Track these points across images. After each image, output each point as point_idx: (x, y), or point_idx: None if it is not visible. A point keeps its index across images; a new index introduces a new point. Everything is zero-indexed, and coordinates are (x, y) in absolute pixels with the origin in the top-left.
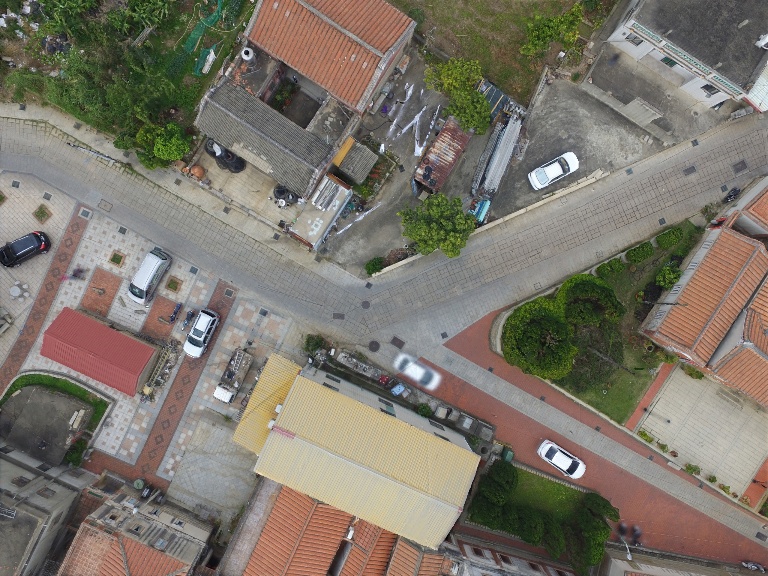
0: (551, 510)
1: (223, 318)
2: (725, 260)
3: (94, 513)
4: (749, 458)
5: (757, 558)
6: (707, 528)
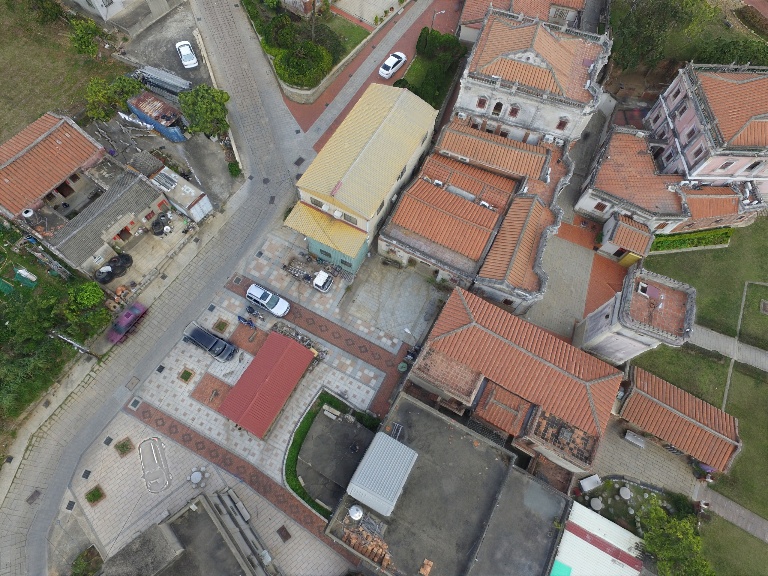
0: None
1: None
2: None
3: None
4: None
5: None
6: None
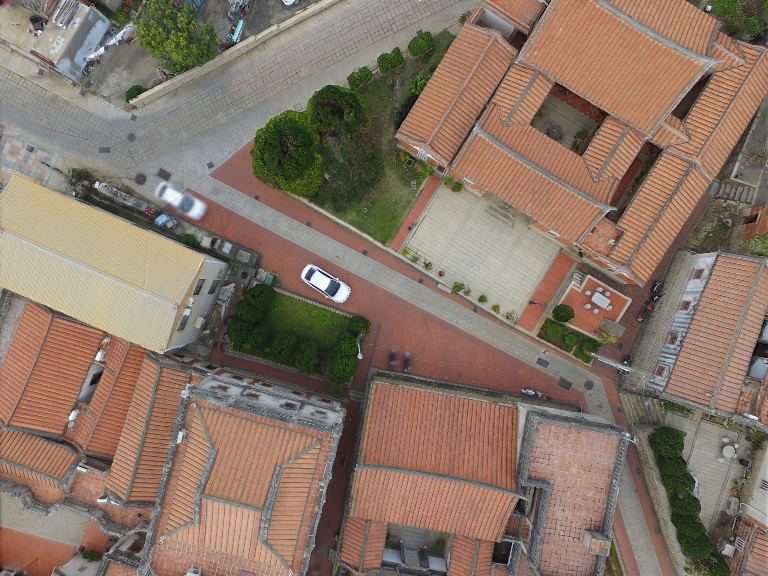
0: (317, 337)
1: None
2: (464, 53)
3: None
4: (524, 278)
5: (539, 386)
6: (483, 354)
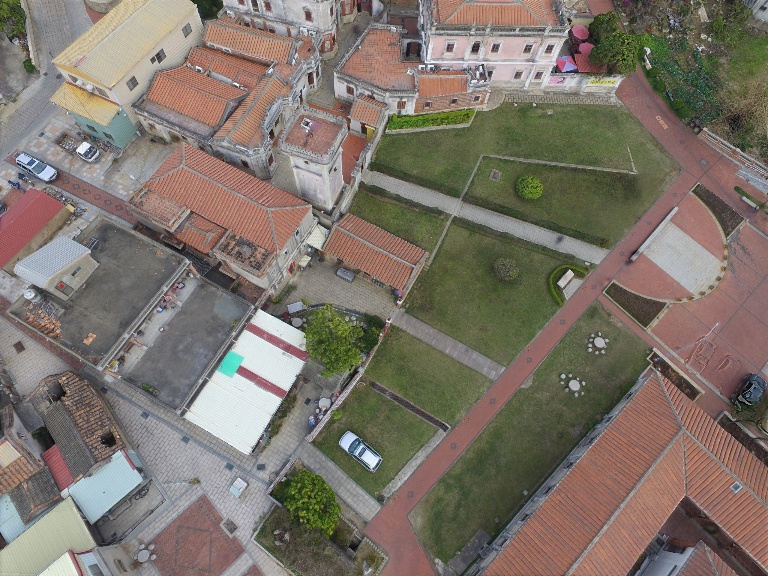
0: None
1: None
2: None
3: None
4: None
5: None
6: None
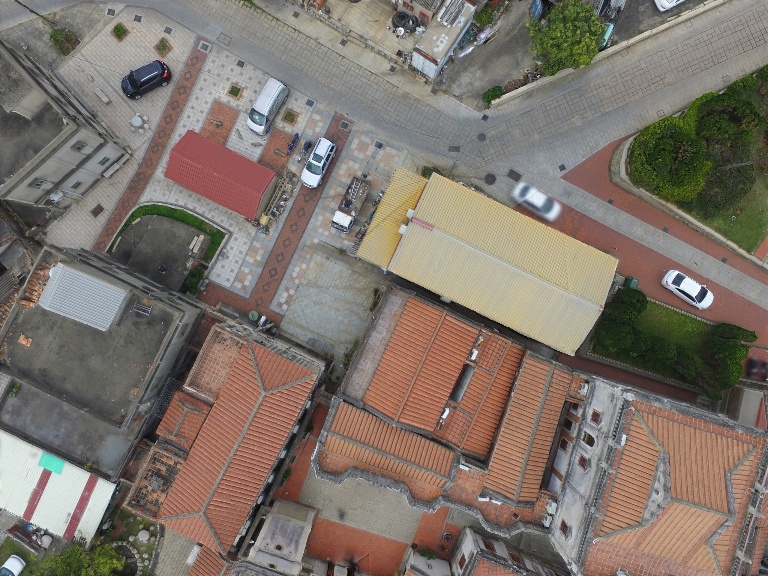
0: (676, 343)
1: (338, 151)
2: None
3: (221, 324)
4: None
5: None
6: None
